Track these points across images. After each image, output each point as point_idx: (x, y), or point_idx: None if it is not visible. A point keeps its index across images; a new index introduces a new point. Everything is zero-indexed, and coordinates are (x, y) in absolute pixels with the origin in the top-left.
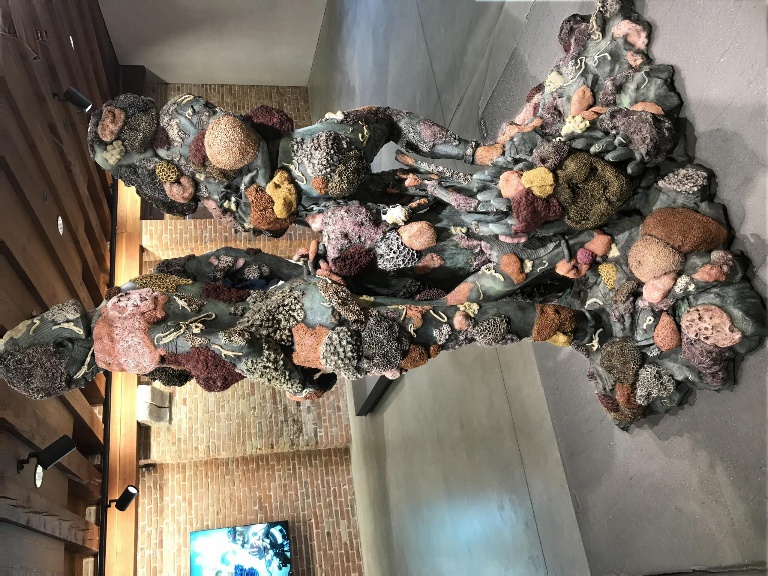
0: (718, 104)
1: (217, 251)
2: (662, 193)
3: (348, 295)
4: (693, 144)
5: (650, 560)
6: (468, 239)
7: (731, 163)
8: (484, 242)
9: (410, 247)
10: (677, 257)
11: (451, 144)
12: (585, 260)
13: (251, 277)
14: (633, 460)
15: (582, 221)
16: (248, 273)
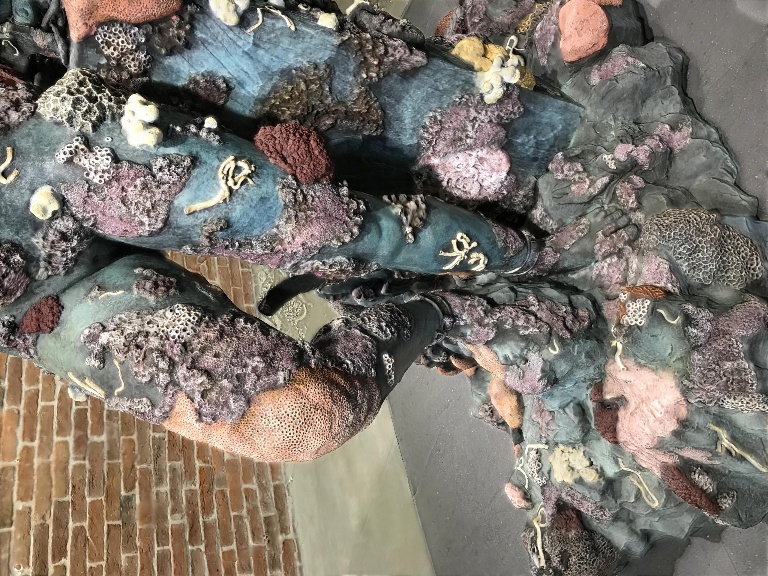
0: None
1: None
2: None
3: None
4: None
5: None
6: None
7: None
8: None
9: None
10: None
11: None
12: None
13: None
14: None
15: None
16: None
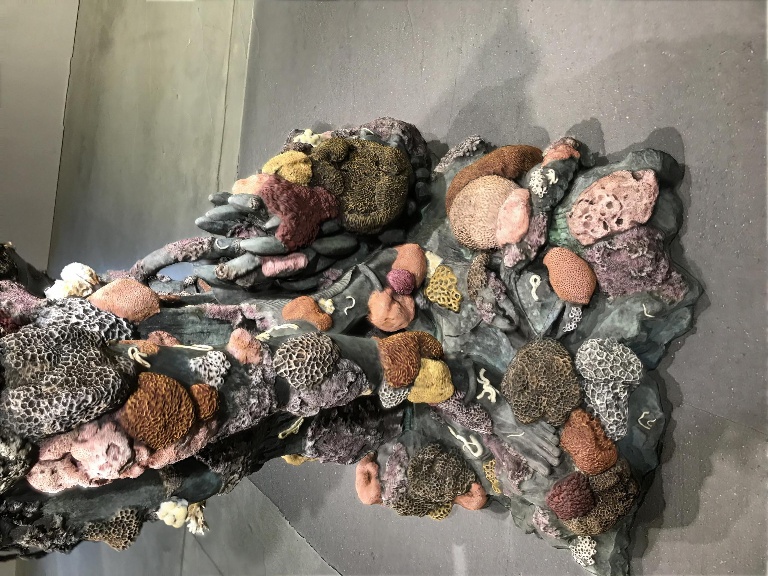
0: (445, 96)
1: None
2: (446, 173)
3: None
4: (446, 152)
5: None
6: (216, 304)
7: (494, 115)
8: (244, 304)
9: (110, 313)
10: (509, 181)
11: (159, 282)
12: (403, 277)
13: None
14: None
15: (370, 213)
16: None
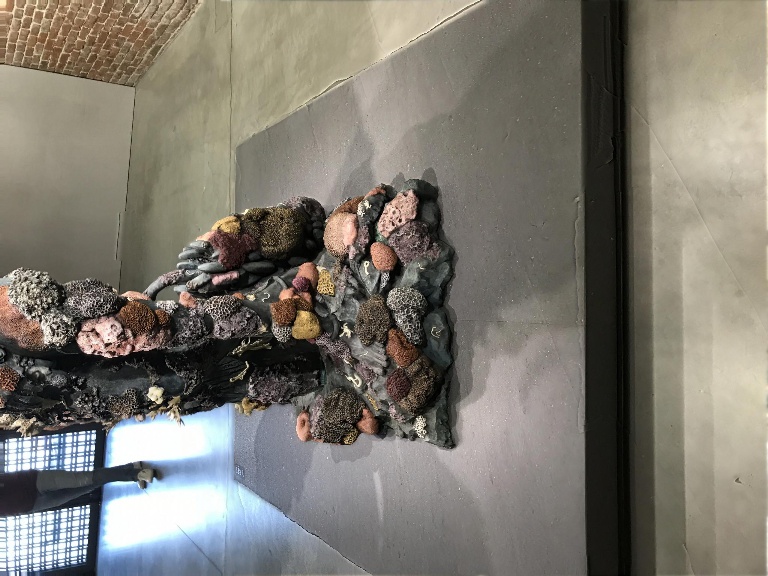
0: (336, 181)
1: None
2: None
3: None
4: None
5: (570, 520)
6: None
7: (359, 184)
8: None
9: None
10: None
11: None
12: (299, 279)
13: None
14: (478, 459)
15: None
16: None
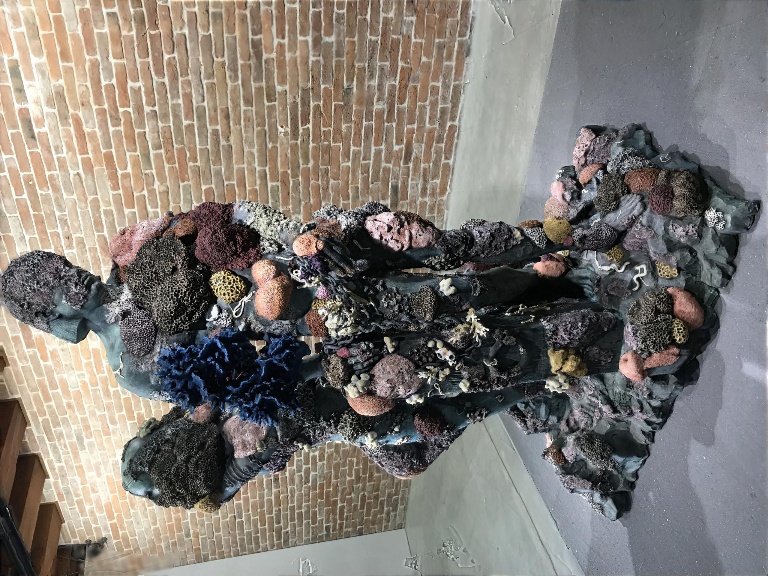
0: None
1: None
2: None
3: None
4: None
5: None
6: None
7: None
8: None
9: None
10: None
11: None
12: None
13: None
14: None
15: None
16: None
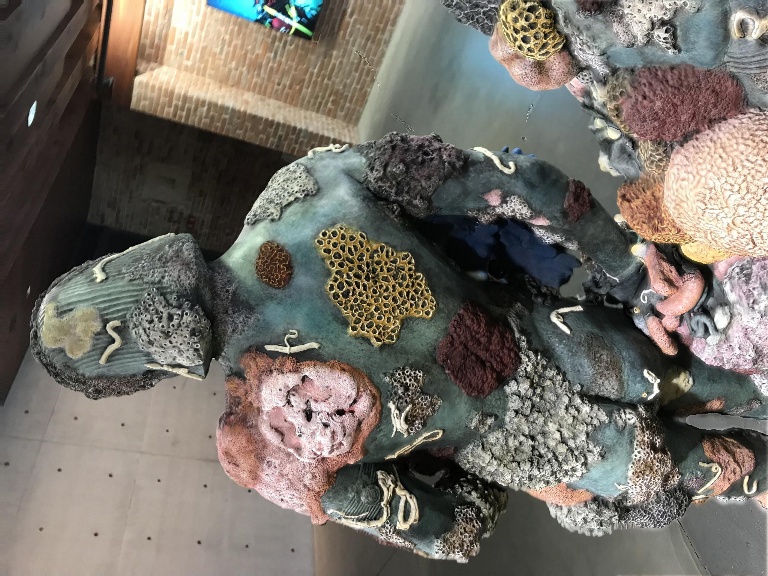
0: None
1: (512, 178)
2: None
3: (664, 473)
4: None
5: None
6: None
7: None
8: None
9: None
10: None
11: None
12: None
13: (537, 233)
14: None
15: None
16: (537, 231)
